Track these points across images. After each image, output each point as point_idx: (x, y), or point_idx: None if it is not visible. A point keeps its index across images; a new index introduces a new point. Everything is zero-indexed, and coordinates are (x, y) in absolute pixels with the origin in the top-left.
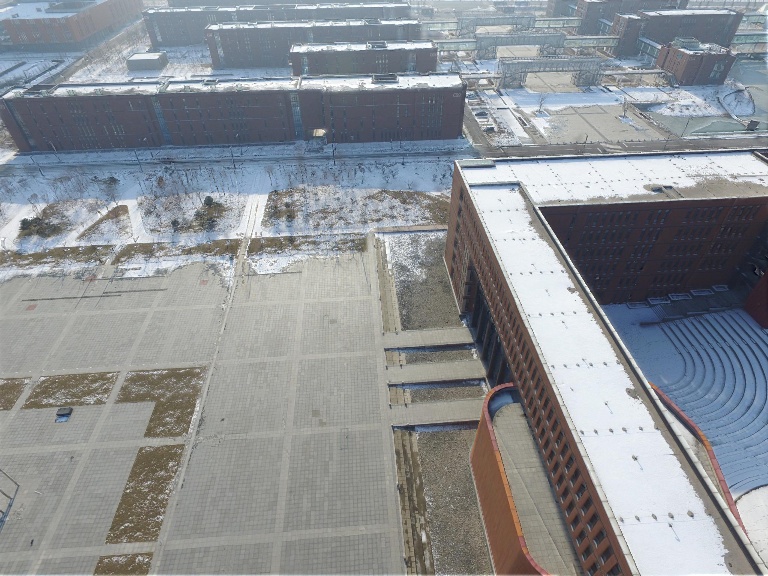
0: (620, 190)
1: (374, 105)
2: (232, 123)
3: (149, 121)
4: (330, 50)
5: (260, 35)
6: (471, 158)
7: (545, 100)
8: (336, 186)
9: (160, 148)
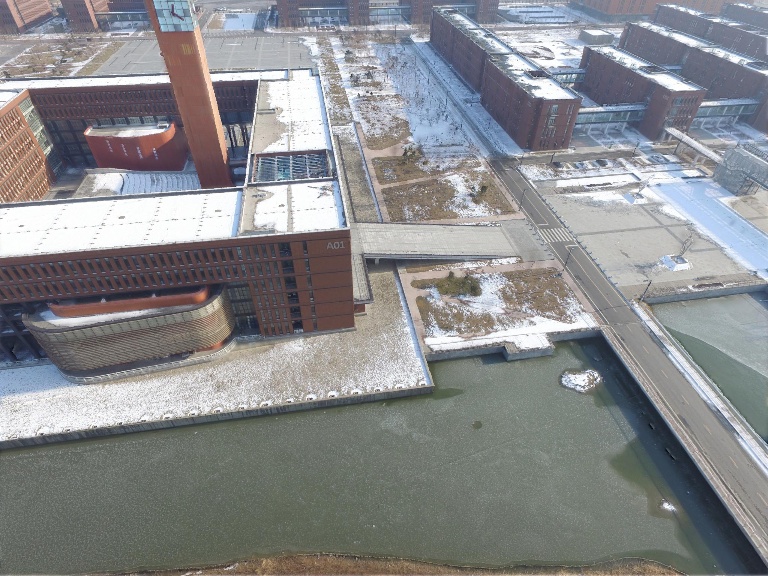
0: (277, 101)
1: (499, 85)
2: (467, 64)
3: (452, 45)
4: (608, 56)
5: (654, 40)
6: (483, 155)
7: (697, 206)
8: (409, 108)
9: (447, 64)
